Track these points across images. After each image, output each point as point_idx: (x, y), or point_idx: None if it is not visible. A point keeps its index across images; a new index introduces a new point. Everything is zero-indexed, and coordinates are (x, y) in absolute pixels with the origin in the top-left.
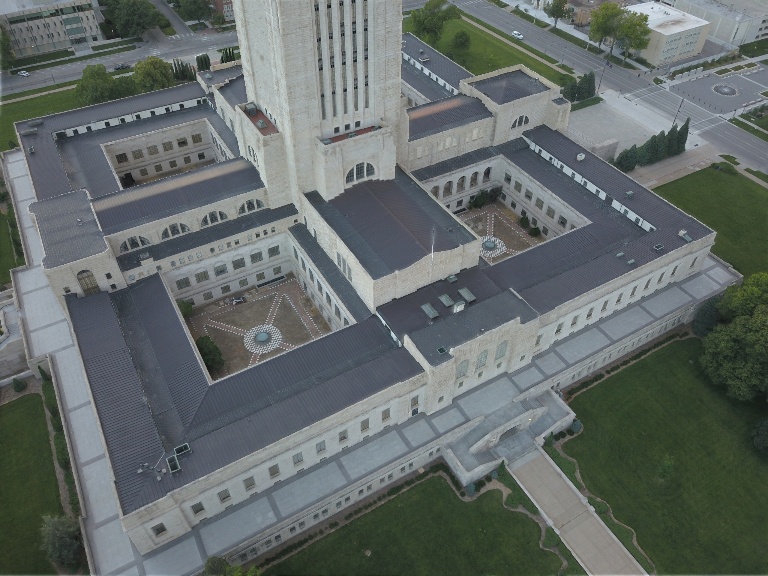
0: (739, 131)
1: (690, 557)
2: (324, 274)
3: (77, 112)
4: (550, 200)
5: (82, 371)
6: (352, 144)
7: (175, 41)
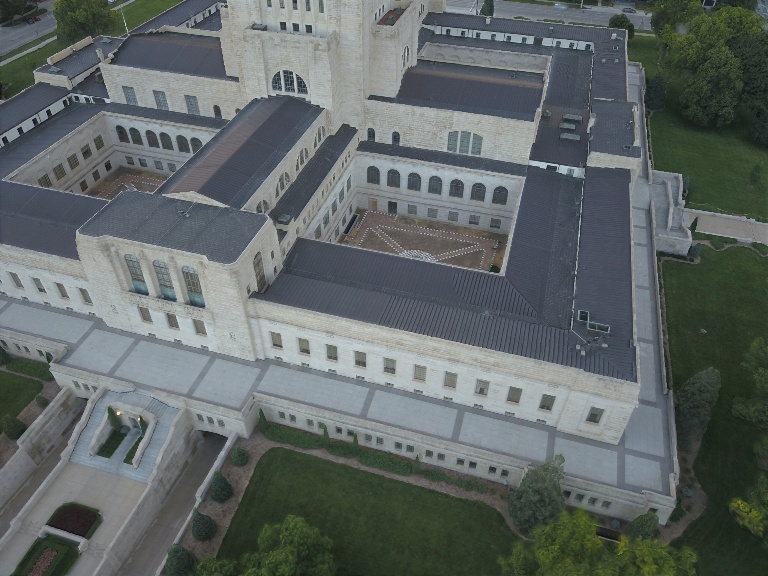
0: (502, 2)
1: None
2: (444, 163)
3: None
4: (499, 58)
5: (396, 332)
6: (403, 23)
7: None
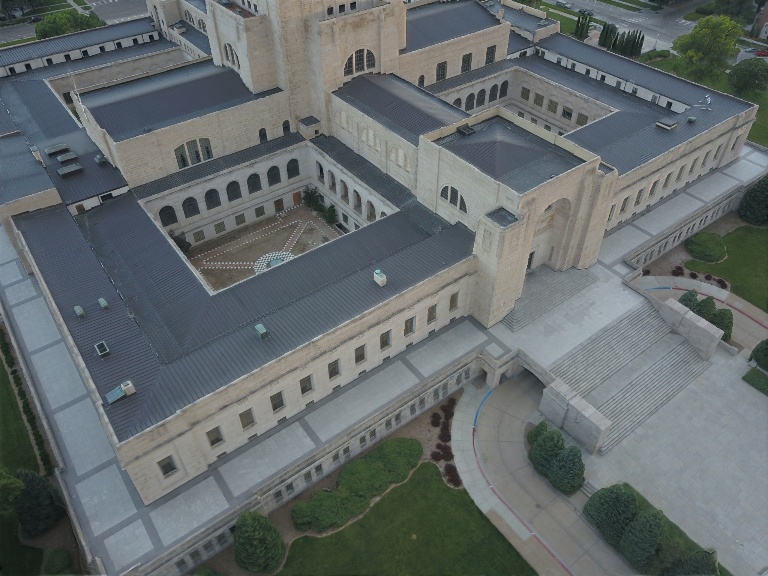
0: None
1: None
2: None
3: None
4: None
5: None
6: None
7: (673, 24)
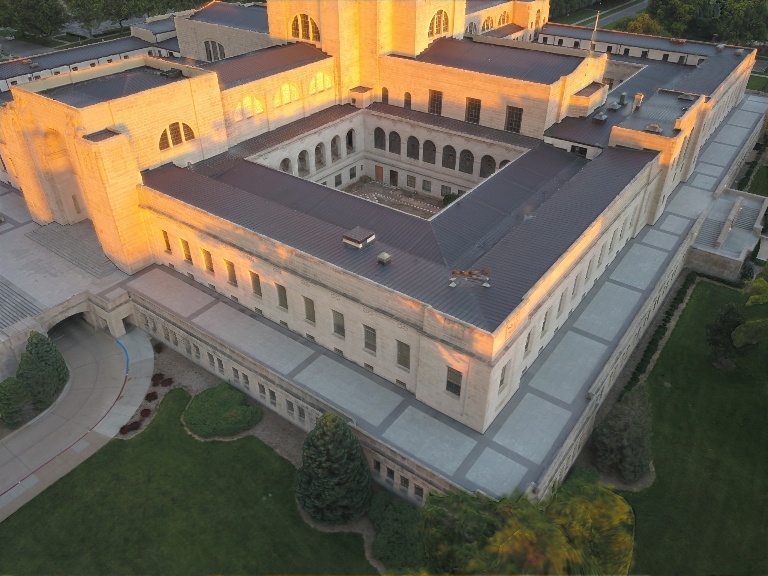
0: None
1: None
2: None
3: (736, 65)
4: None
5: None
6: None
7: None
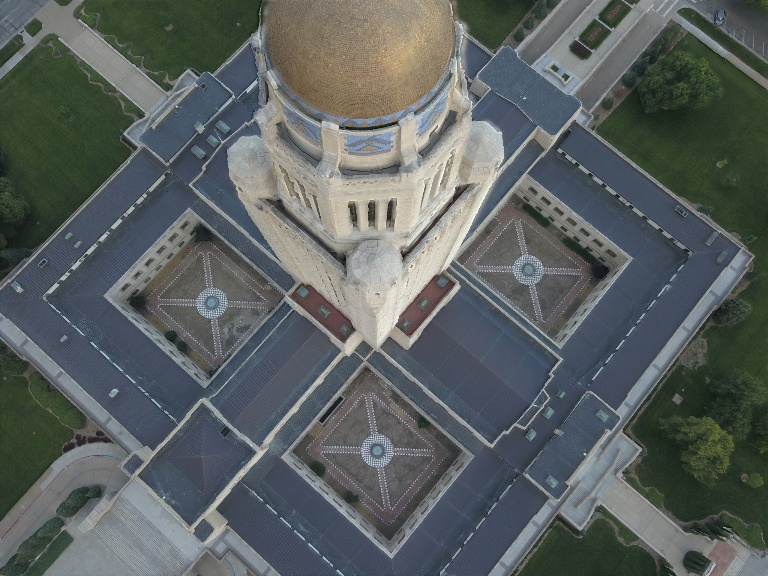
0: None
1: (58, 77)
2: None
3: (699, 295)
4: None
5: None
6: None
7: None
